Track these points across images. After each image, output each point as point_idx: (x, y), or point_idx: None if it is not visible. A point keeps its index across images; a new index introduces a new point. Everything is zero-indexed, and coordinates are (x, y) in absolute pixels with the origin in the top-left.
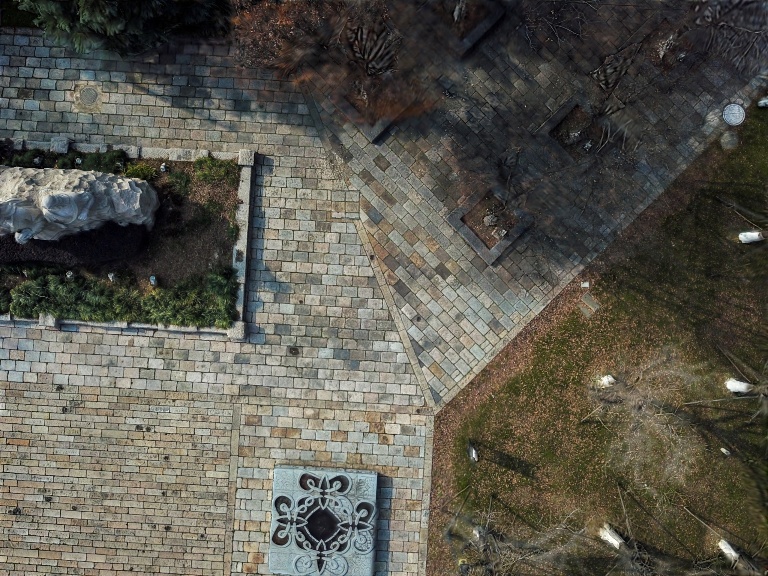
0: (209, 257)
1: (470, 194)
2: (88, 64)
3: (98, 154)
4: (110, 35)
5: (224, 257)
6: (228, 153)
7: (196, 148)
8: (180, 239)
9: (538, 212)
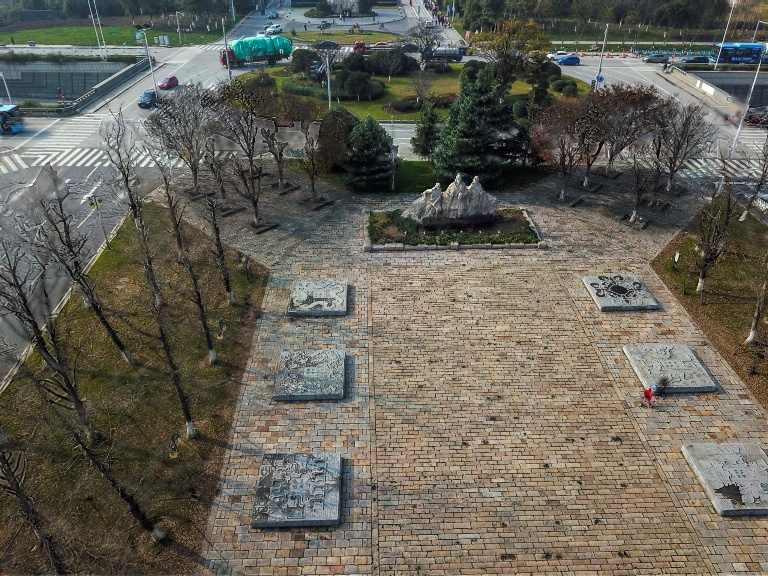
0: None
1: None
2: None
3: None
4: (475, 166)
5: None
6: None
7: None
8: (506, 224)
9: None
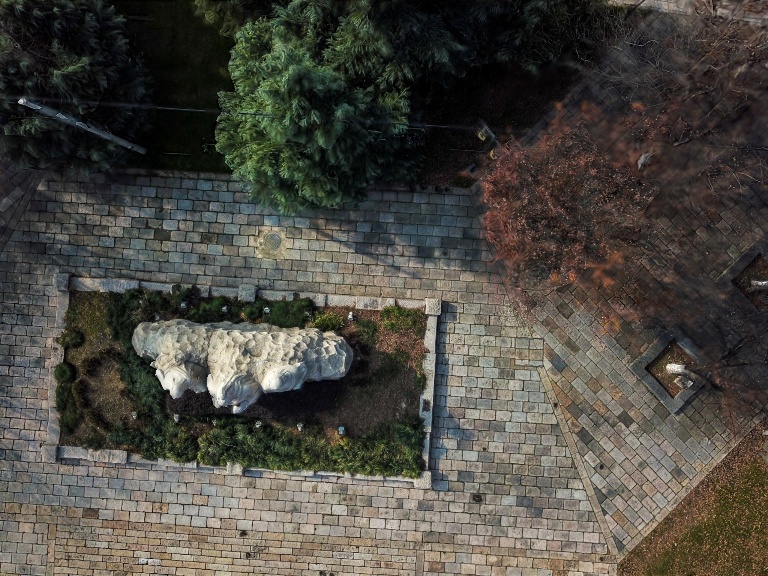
0: (396, 406)
1: (653, 342)
2: (272, 210)
3: (285, 302)
4: (324, 205)
5: (411, 406)
6: (414, 301)
7: (380, 294)
8: (368, 389)
9: (760, 392)
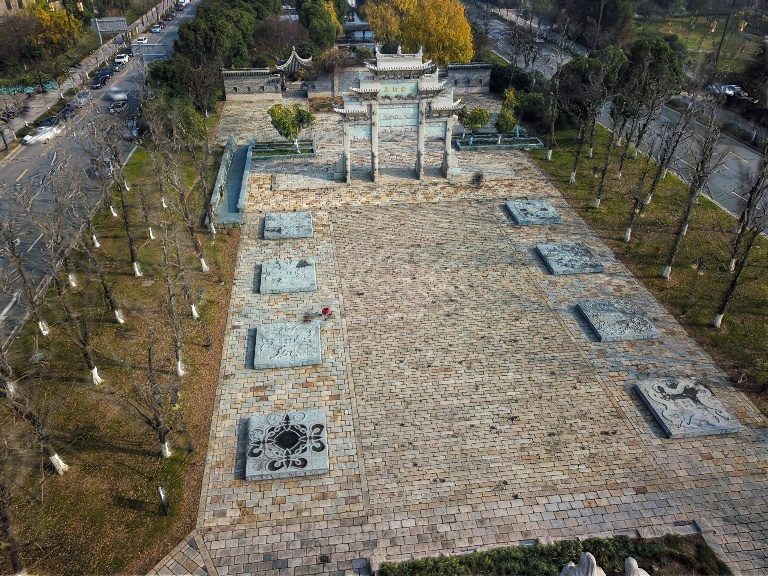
0: None
1: None
2: None
3: None
4: None
5: None
6: None
7: None
8: None
9: None
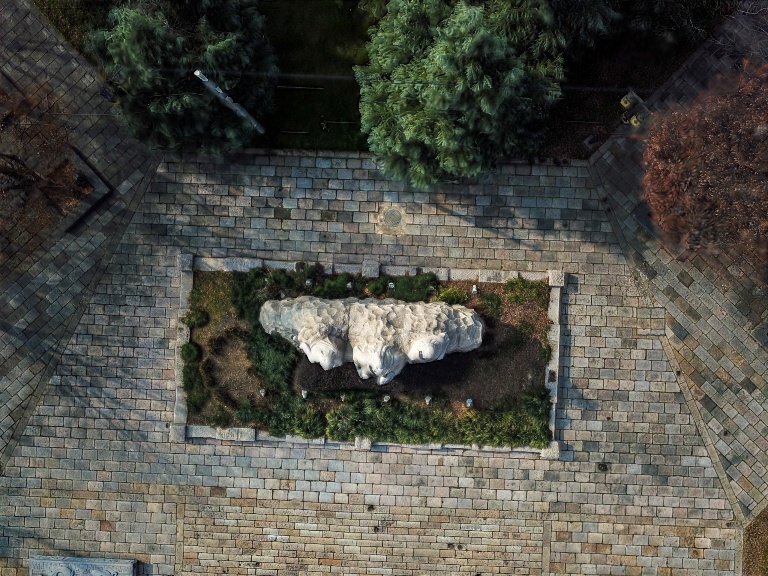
0: (522, 378)
1: None
2: (392, 186)
3: (409, 277)
4: None
5: (536, 377)
6: (536, 273)
7: (501, 267)
8: (494, 361)
9: None
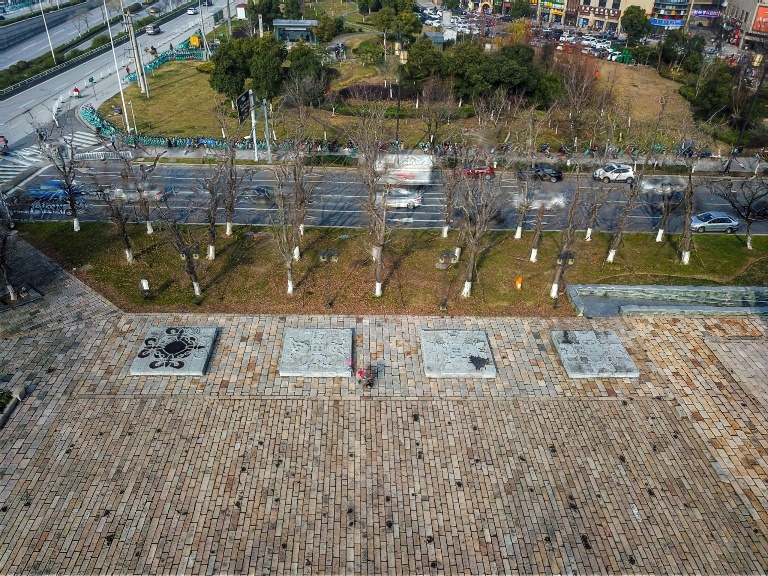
0: None
1: None
2: None
3: None
4: None
5: None
6: None
7: None
8: None
9: None
